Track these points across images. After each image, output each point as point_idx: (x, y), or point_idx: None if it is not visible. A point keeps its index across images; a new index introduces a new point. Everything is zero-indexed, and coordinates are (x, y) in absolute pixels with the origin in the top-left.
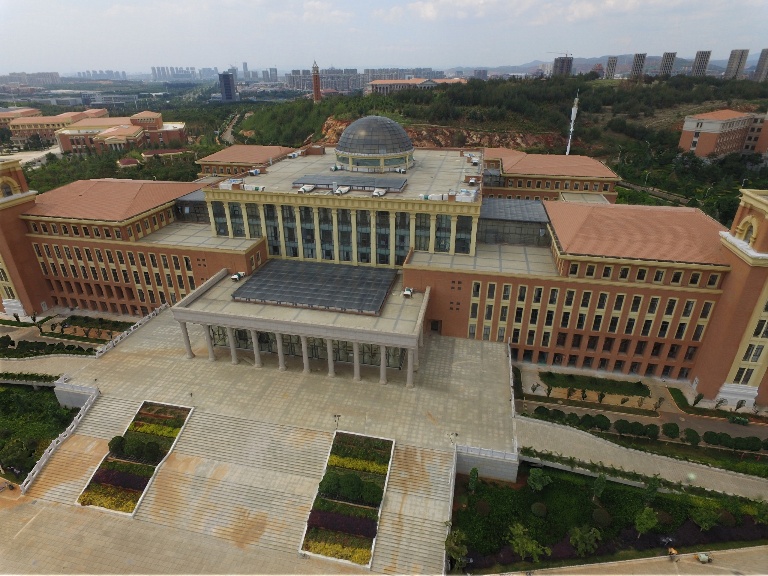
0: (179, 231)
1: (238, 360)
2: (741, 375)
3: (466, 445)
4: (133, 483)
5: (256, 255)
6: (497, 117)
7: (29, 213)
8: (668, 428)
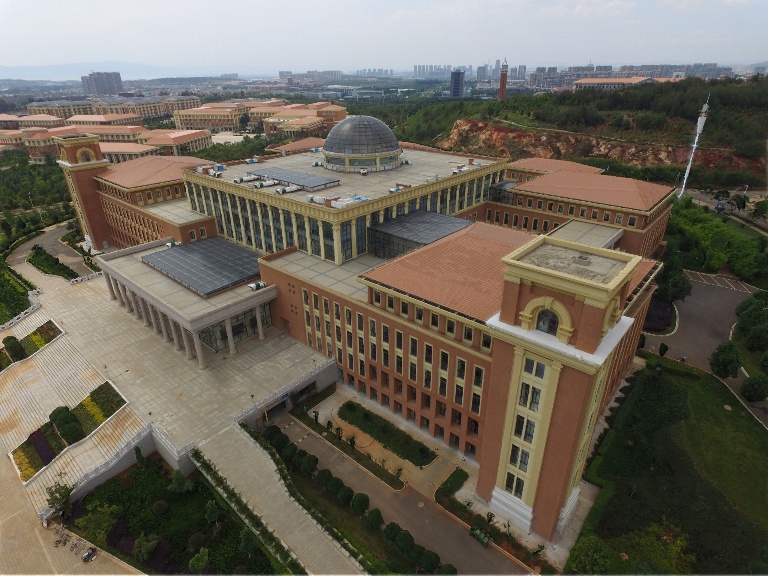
0: (180, 203)
1: (131, 309)
2: (513, 483)
3: (154, 426)
4: None
5: (200, 230)
6: (652, 125)
7: (98, 175)
8: (354, 498)
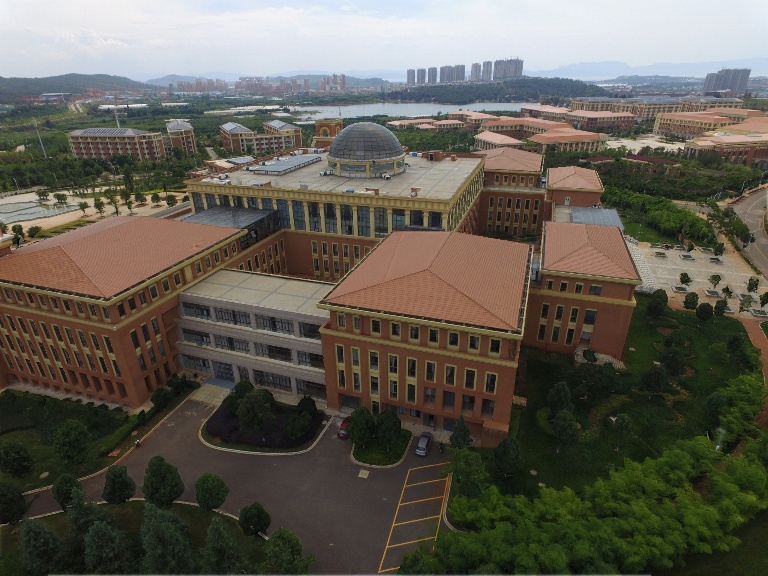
0: None
1: None
2: None
3: None
4: None
5: None
6: None
7: None
8: None
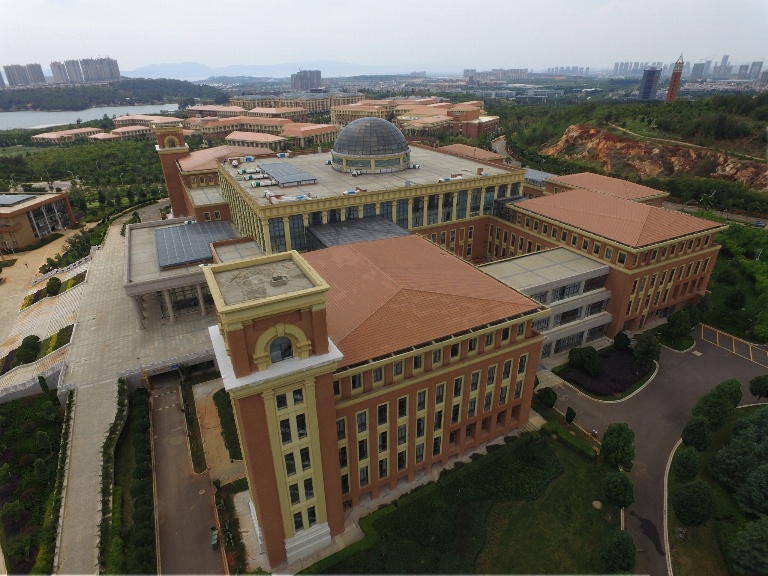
0: None
1: None
2: None
3: None
4: (34, 299)
5: (214, 213)
6: None
7: (179, 159)
8: None
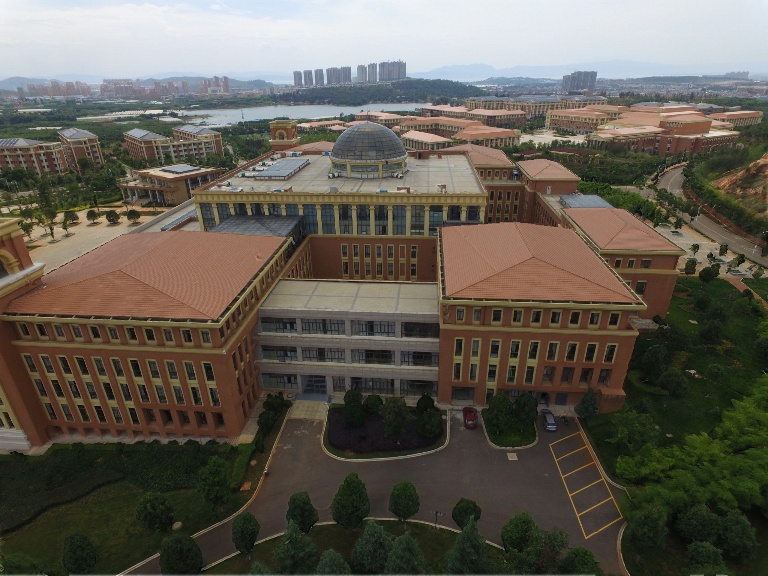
0: None
1: None
2: None
3: None
4: None
5: None
6: None
7: None
8: None
